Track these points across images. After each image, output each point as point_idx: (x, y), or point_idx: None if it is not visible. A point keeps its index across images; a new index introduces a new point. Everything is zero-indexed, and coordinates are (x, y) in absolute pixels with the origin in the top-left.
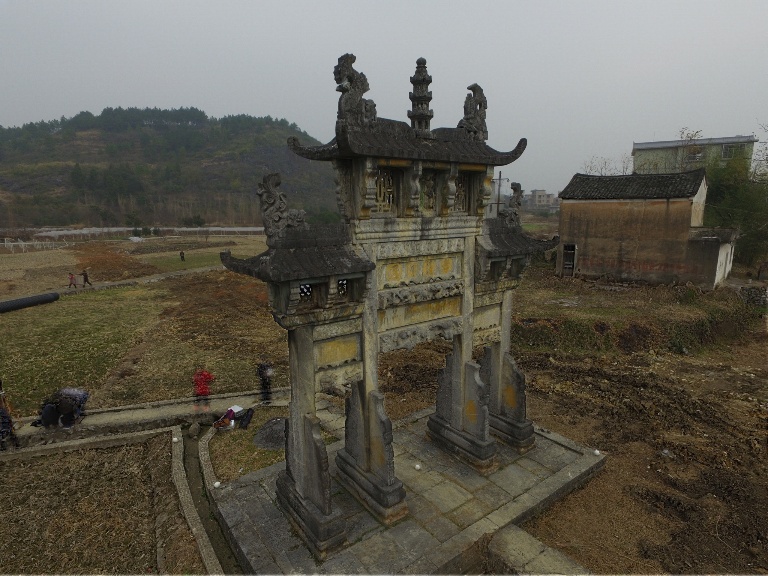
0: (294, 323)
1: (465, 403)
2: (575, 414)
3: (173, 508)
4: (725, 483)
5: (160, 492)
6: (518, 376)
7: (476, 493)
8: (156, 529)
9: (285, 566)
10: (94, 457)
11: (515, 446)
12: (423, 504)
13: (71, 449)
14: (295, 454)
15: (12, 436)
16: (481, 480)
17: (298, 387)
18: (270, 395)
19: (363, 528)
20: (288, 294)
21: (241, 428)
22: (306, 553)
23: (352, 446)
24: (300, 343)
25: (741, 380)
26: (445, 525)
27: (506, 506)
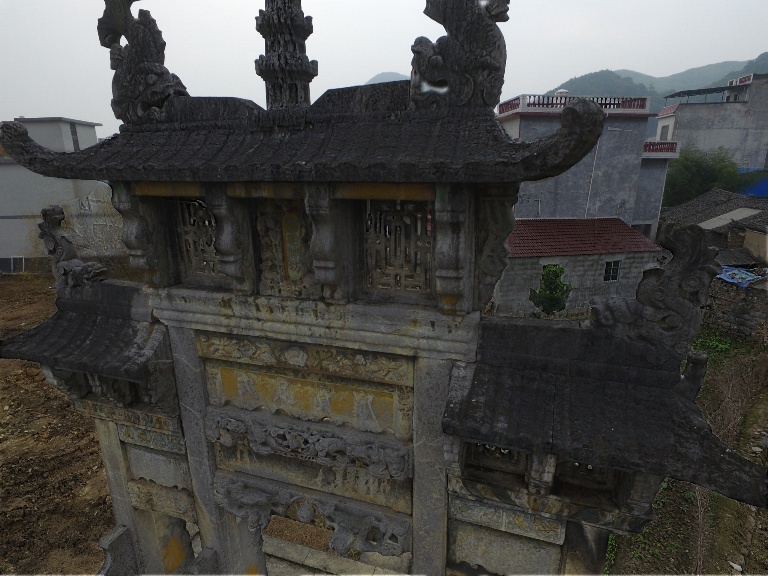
0: None
1: None
2: None
3: None
4: None
5: None
6: None
7: None
8: None
9: None
10: None
11: None
12: None
13: None
14: None
15: None
16: None
17: None
18: None
19: None
20: None
21: None
22: None
23: None
24: None
25: None
26: None
27: (339, 572)
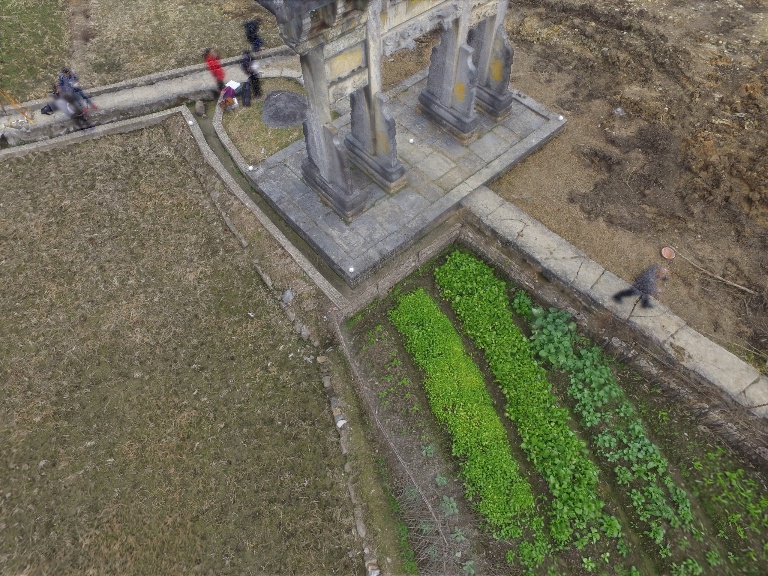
0: (306, 49)
1: (455, 84)
2: (553, 70)
3: (221, 187)
4: (653, 137)
5: (202, 173)
6: (508, 52)
7: (458, 162)
8: (215, 203)
9: (325, 227)
10: (123, 142)
11: (494, 115)
12: (417, 174)
13: (97, 136)
14: (318, 152)
15: (34, 127)
16: (463, 150)
17: (316, 104)
18: (259, 62)
19: (374, 197)
20: (299, 24)
21: (246, 106)
22: (337, 218)
23: (358, 133)
24: (313, 65)
25: (725, 15)
26: (434, 190)
27: (480, 172)
